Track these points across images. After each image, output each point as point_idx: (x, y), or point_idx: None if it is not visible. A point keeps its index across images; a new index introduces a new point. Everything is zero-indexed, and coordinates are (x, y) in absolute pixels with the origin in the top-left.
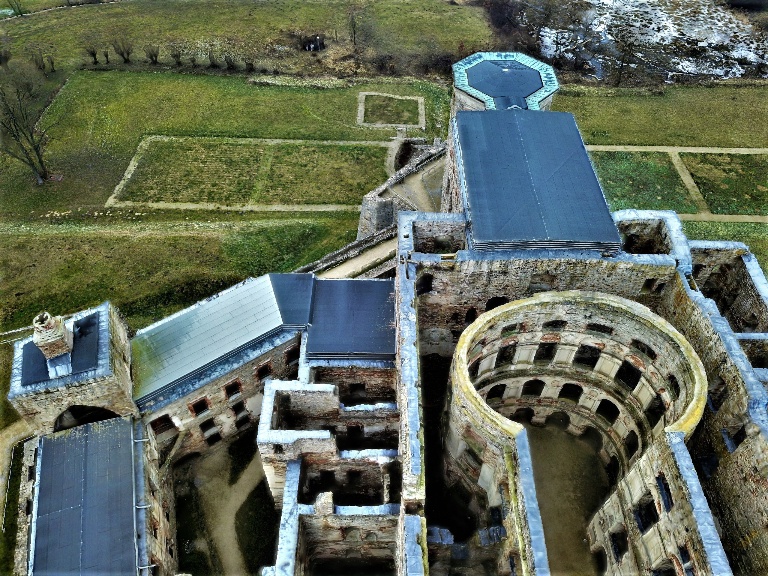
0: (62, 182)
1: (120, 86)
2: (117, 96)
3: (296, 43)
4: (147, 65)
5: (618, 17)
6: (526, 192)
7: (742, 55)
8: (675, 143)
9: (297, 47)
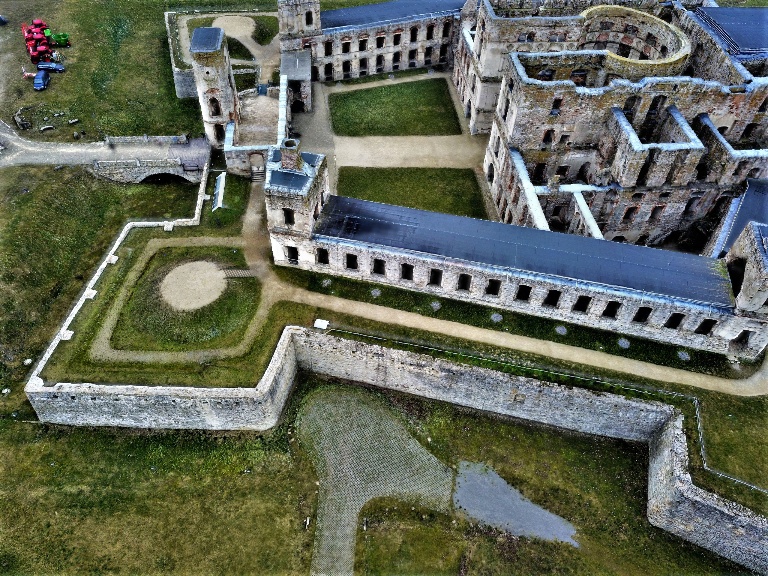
0: None
1: None
2: None
3: None
4: None
5: None
6: (760, 21)
7: None
8: None
9: None
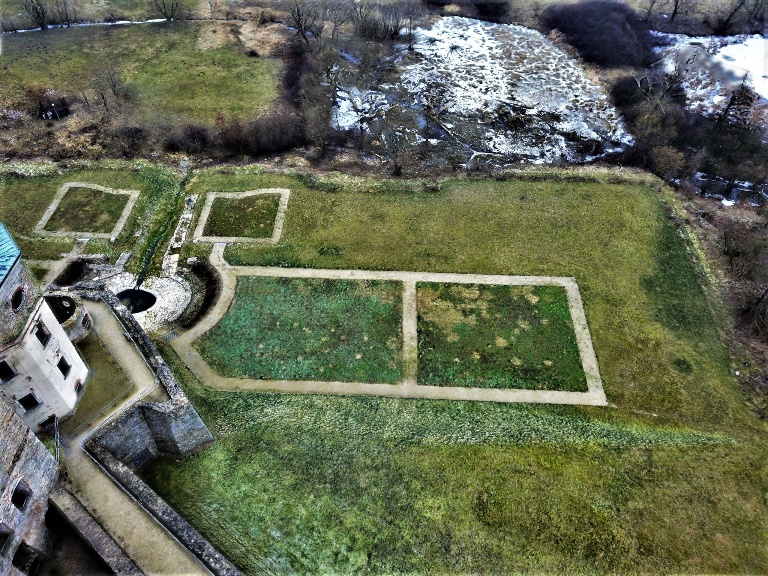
0: None
1: None
2: None
3: (37, 108)
4: None
5: (445, 73)
6: None
7: (573, 127)
8: (419, 267)
9: (35, 114)
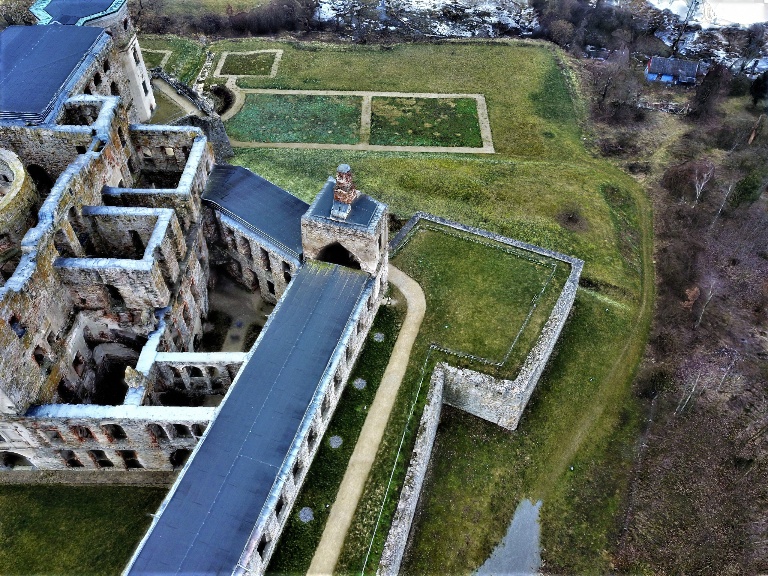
0: None
1: None
2: None
3: None
4: None
5: None
6: None
7: (500, 20)
8: (374, 89)
9: None
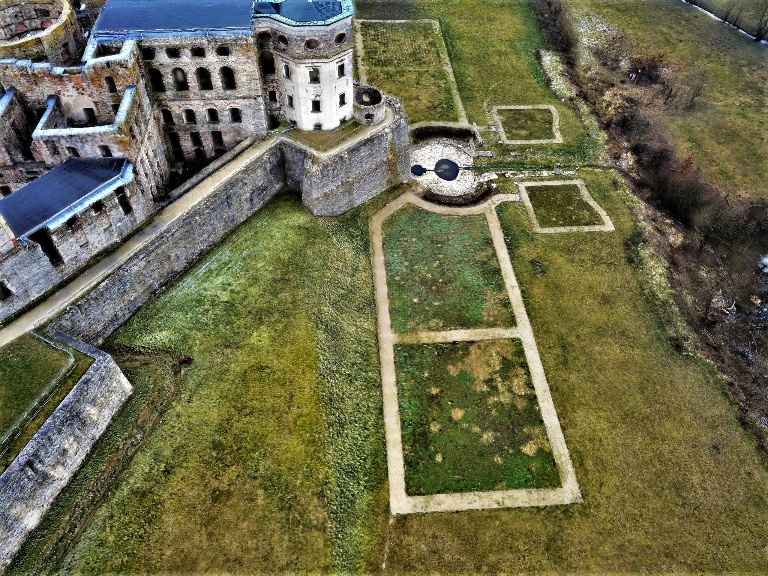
0: (375, 3)
1: (501, 1)
2: (485, 2)
3: None
4: (544, 8)
5: None
6: (152, 4)
7: None
8: (542, 338)
9: None
